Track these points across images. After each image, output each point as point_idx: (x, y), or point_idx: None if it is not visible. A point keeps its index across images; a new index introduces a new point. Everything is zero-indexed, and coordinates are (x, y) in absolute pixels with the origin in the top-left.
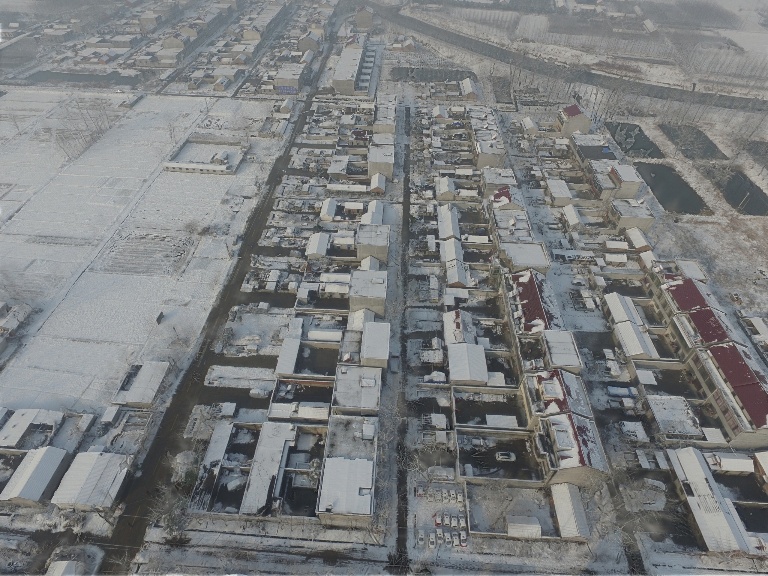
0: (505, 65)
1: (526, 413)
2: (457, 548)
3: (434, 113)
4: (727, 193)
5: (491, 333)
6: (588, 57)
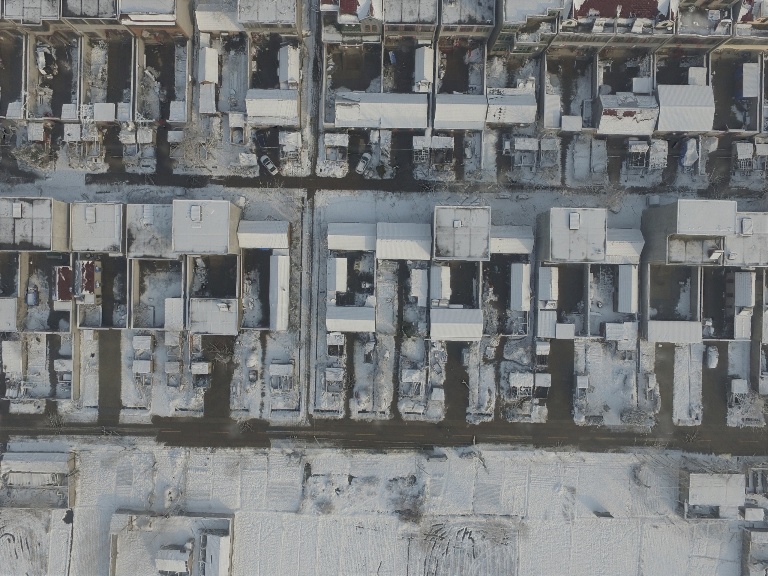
0: None
1: None
2: None
3: None
4: None
5: (607, 75)
6: None
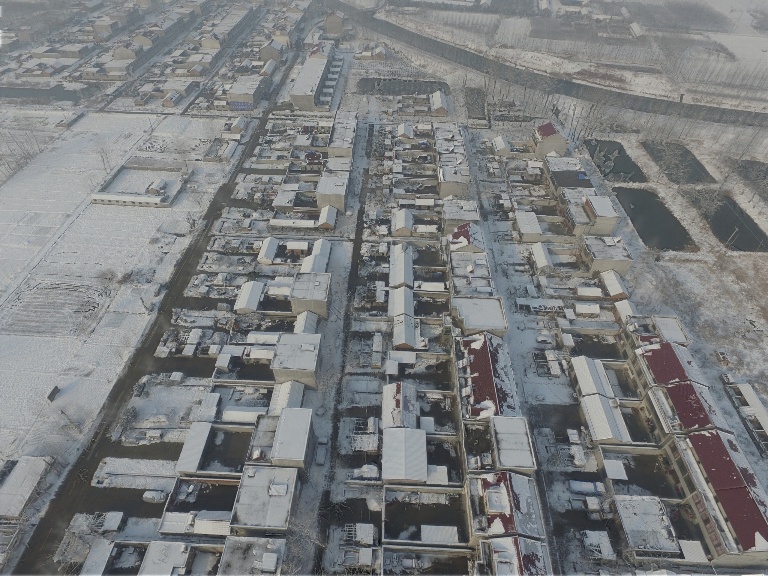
0: (480, 75)
1: None
2: None
3: (398, 132)
4: (714, 225)
5: (439, 408)
6: (570, 65)
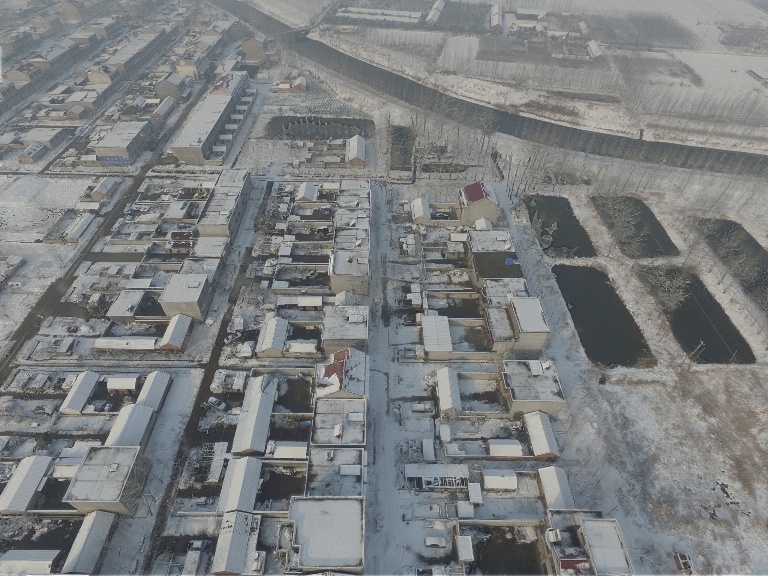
0: (412, 111)
1: None
2: None
3: (298, 194)
4: (675, 322)
5: None
6: (516, 95)
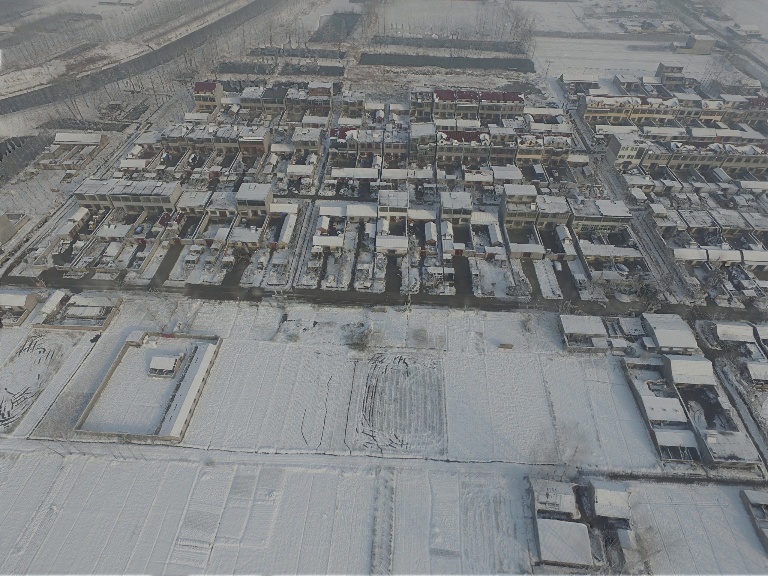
0: (26, 111)
1: (534, 158)
2: (607, 193)
3: (136, 166)
4: (321, 73)
5: None
6: (49, 69)
